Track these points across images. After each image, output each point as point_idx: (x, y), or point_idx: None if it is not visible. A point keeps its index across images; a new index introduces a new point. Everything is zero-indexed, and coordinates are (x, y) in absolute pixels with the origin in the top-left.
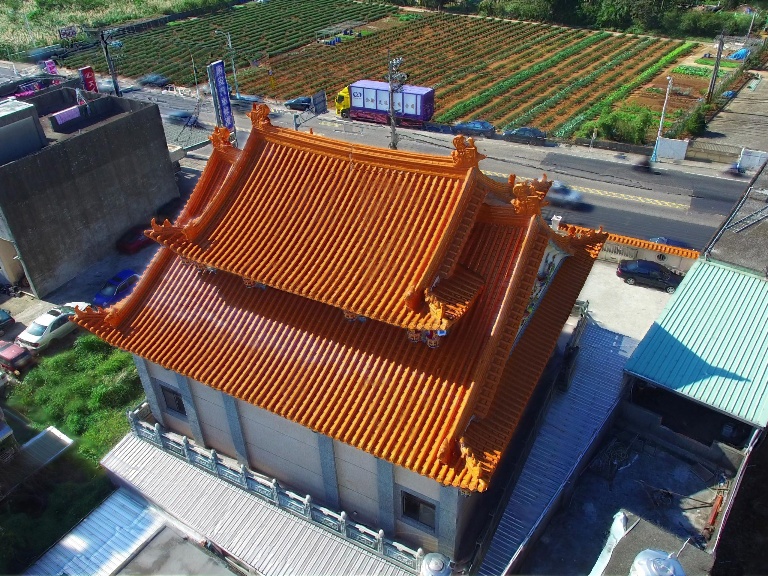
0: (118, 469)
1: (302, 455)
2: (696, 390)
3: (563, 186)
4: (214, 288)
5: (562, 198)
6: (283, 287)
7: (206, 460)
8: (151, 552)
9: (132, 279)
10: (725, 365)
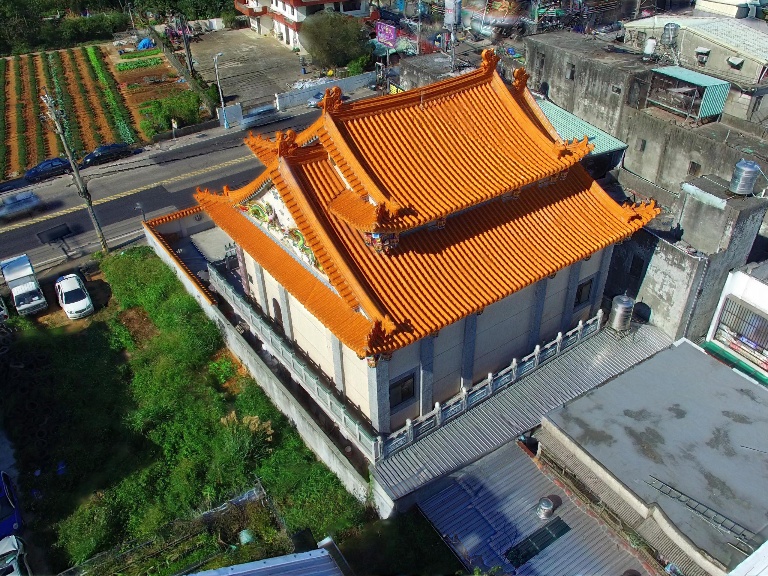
0: (413, 485)
1: (516, 326)
2: (596, 150)
3: (208, 170)
4: (411, 253)
5: (223, 176)
6: (494, 195)
7: (458, 405)
8: (570, 428)
9: (4, 480)
10: (582, 137)
